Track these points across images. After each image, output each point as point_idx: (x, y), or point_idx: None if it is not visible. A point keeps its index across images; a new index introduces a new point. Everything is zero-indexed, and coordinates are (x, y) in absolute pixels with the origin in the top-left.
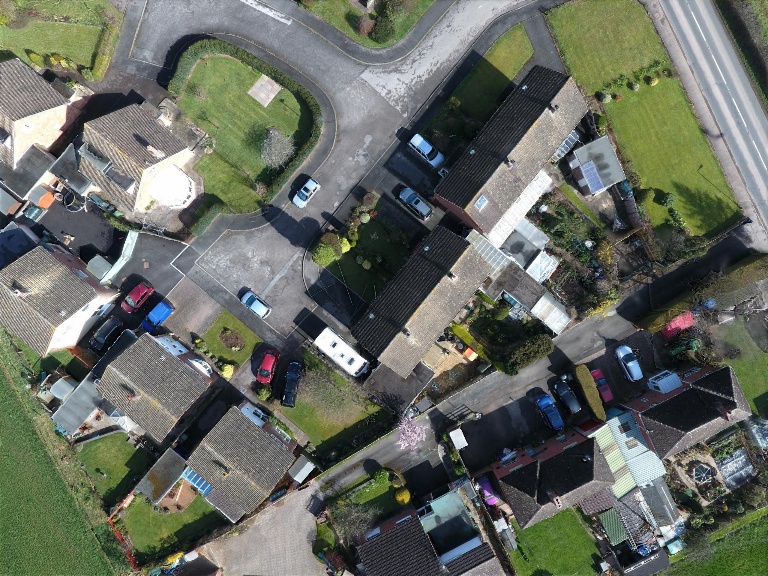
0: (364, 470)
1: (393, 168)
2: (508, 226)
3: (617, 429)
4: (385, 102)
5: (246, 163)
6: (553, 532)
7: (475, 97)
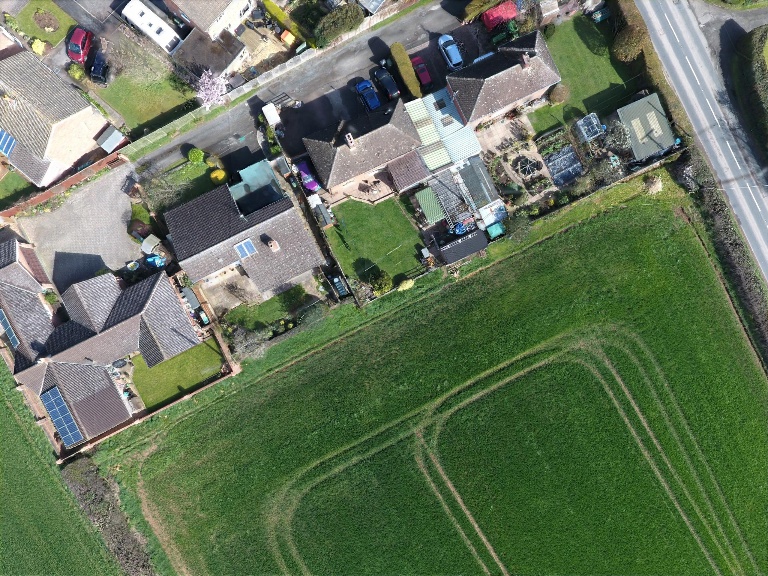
0: (181, 154)
1: None
2: None
3: (432, 106)
4: None
5: None
6: (375, 222)
7: None
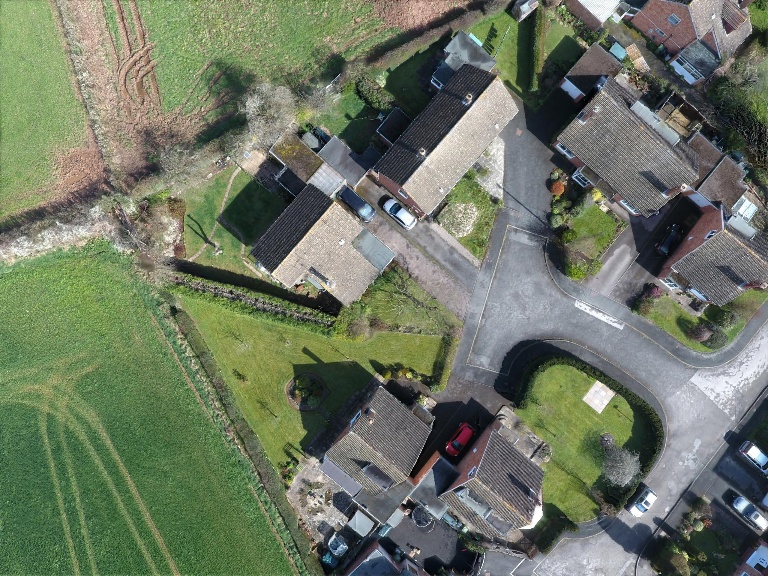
0: None
1: (723, 473)
2: None
3: None
4: (714, 406)
5: (582, 470)
6: None
7: None
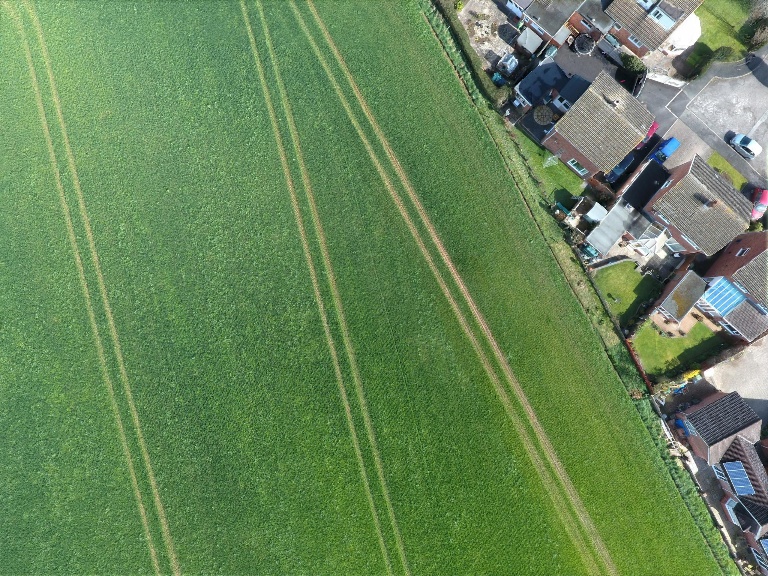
0: None
1: None
2: None
3: None
4: None
5: (730, 16)
6: None
7: None
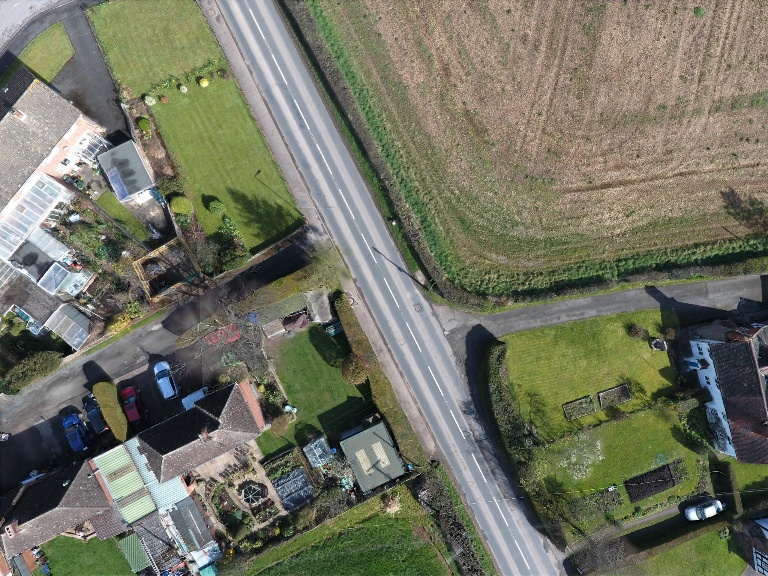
0: None
1: None
2: (15, 237)
3: (136, 450)
4: None
5: None
6: (88, 558)
7: None
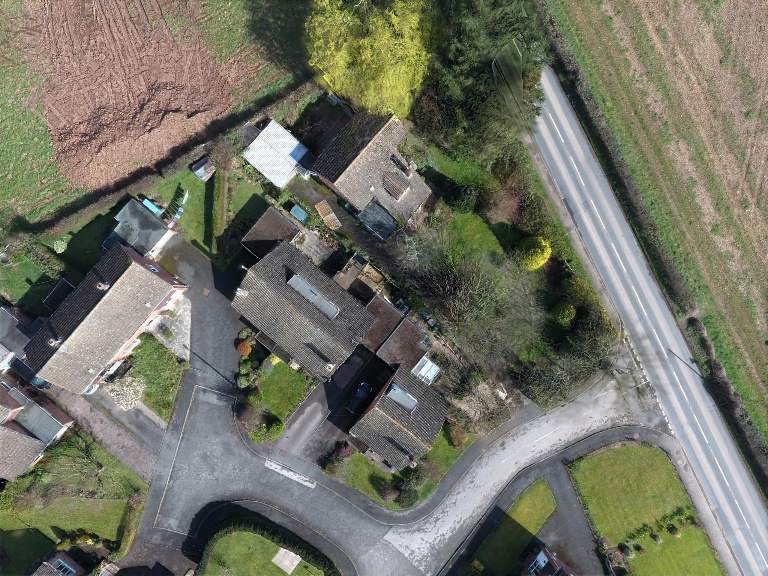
0: None
1: None
2: None
3: None
4: (408, 563)
5: None
6: None
7: (498, 555)
